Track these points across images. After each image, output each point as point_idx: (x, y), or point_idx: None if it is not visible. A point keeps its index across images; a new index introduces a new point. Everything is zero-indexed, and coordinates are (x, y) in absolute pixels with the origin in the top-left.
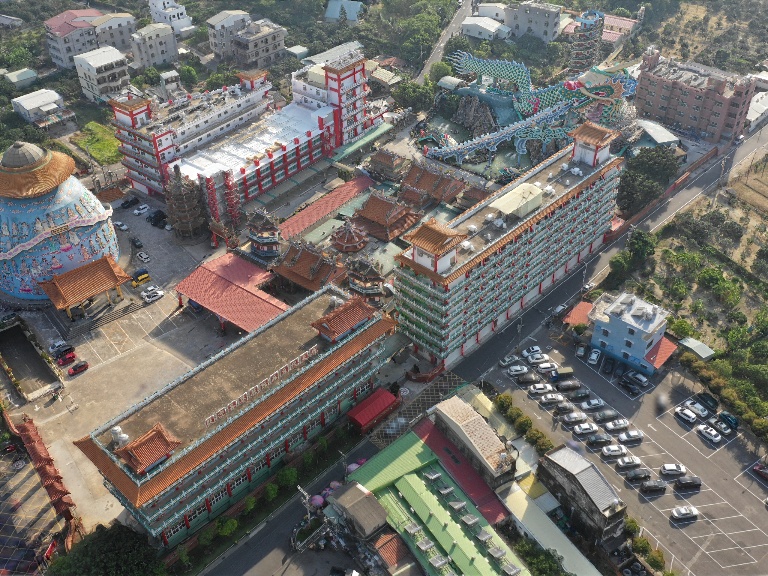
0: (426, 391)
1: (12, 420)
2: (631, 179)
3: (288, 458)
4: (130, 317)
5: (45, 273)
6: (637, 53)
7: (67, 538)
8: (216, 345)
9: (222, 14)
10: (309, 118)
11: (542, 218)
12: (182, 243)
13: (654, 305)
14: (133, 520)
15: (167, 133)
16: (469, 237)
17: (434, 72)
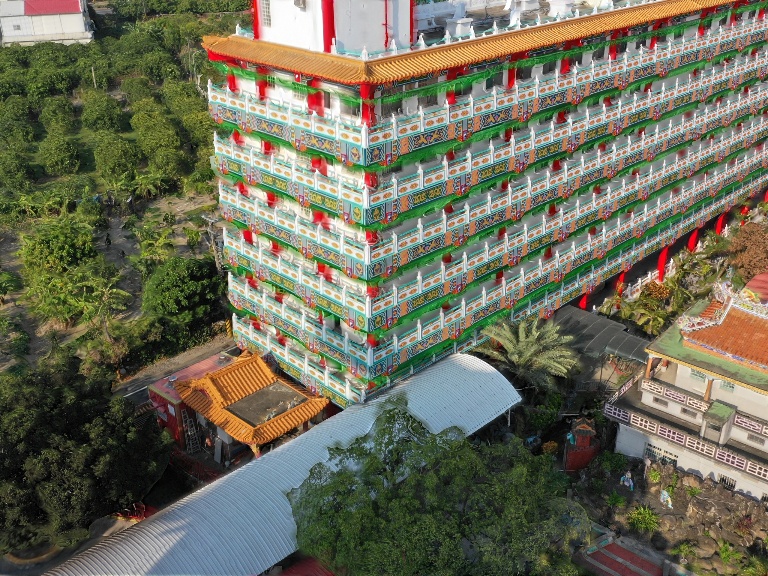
0: None
1: None
2: (16, 396)
3: None
4: None
5: None
6: None
7: None
8: None
9: None
10: None
11: None
12: None
13: None
14: None
15: None
16: None
17: None
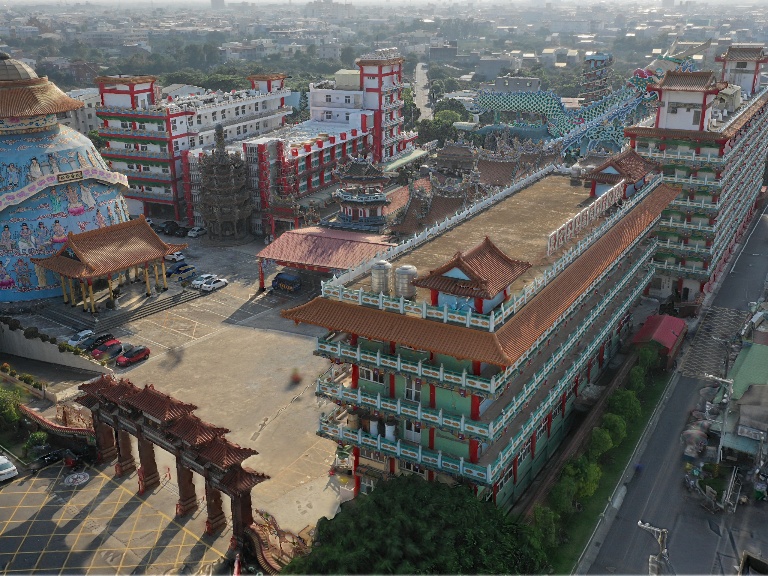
0: (703, 324)
1: (34, 426)
2: None
3: (585, 402)
4: (187, 305)
5: (40, 249)
6: None
7: (261, 553)
8: None
9: (174, 86)
10: None
11: (752, 116)
12: (221, 244)
13: None
14: None
15: (182, 114)
16: None
17: None
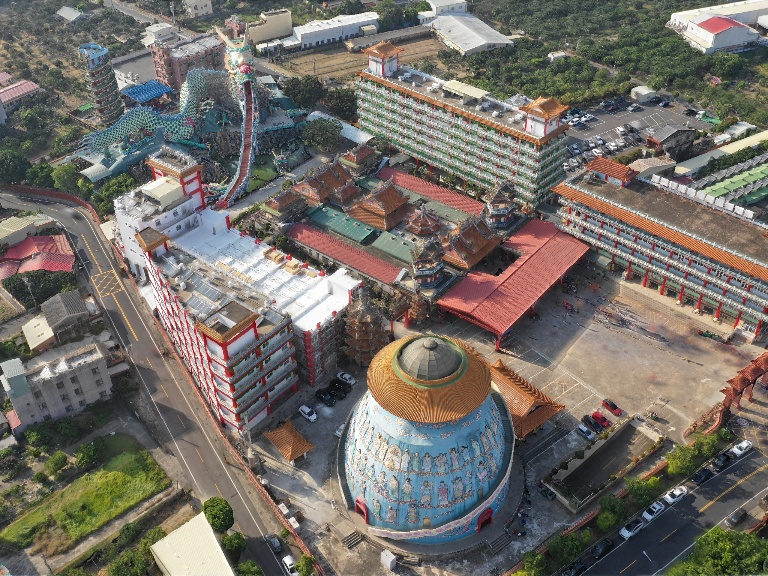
0: None
1: None
2: None
3: None
4: None
5: None
6: (64, 84)
7: None
8: (552, 320)
9: None
10: (198, 239)
11: None
12: None
13: (518, 94)
14: (762, 338)
15: None
16: (506, 117)
17: (68, 179)
